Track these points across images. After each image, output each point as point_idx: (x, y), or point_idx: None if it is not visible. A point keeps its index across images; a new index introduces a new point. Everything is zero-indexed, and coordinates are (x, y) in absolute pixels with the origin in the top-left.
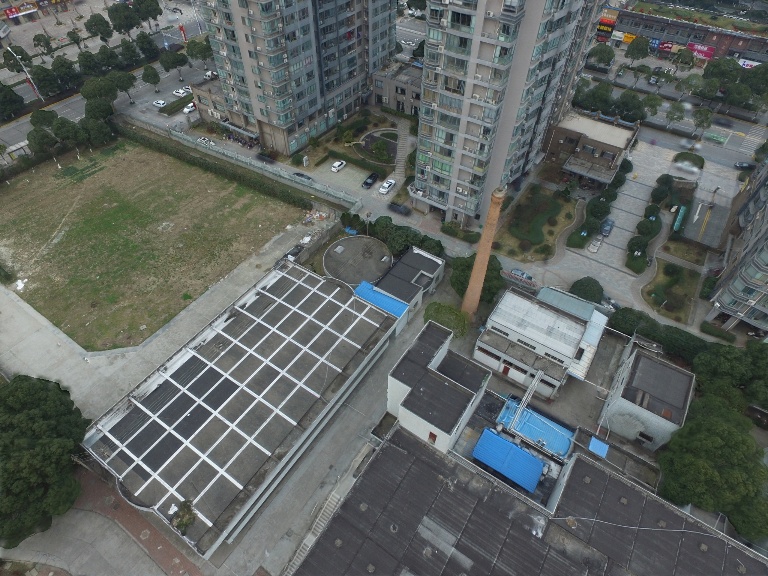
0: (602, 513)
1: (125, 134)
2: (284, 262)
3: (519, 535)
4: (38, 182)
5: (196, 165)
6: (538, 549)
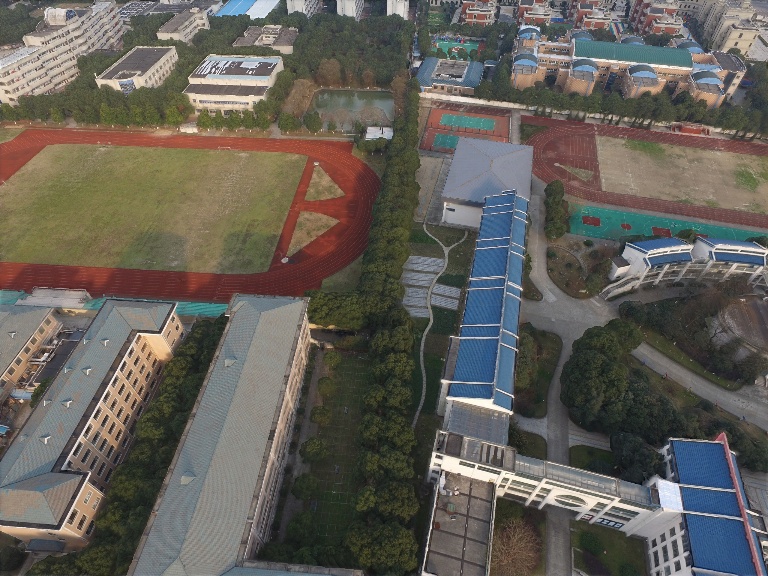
0: (198, 2)
1: (56, 1)
2: (130, 2)
3: (185, 5)
4: (39, 12)
5: (88, 3)
6: (188, 5)
